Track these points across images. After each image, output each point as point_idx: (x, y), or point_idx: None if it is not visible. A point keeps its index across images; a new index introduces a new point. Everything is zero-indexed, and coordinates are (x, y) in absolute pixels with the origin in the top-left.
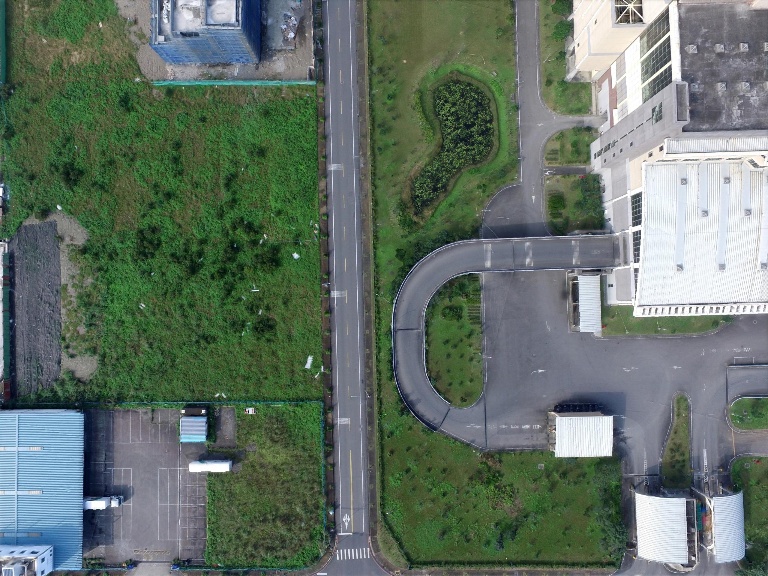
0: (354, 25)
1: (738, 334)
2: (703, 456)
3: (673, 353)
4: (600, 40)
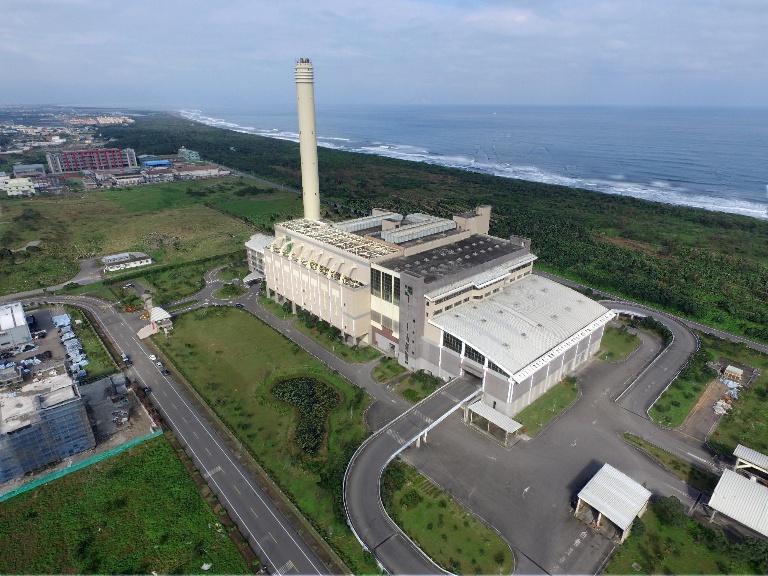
0: (181, 393)
1: (592, 387)
2: (695, 458)
3: (580, 417)
4: (354, 305)
